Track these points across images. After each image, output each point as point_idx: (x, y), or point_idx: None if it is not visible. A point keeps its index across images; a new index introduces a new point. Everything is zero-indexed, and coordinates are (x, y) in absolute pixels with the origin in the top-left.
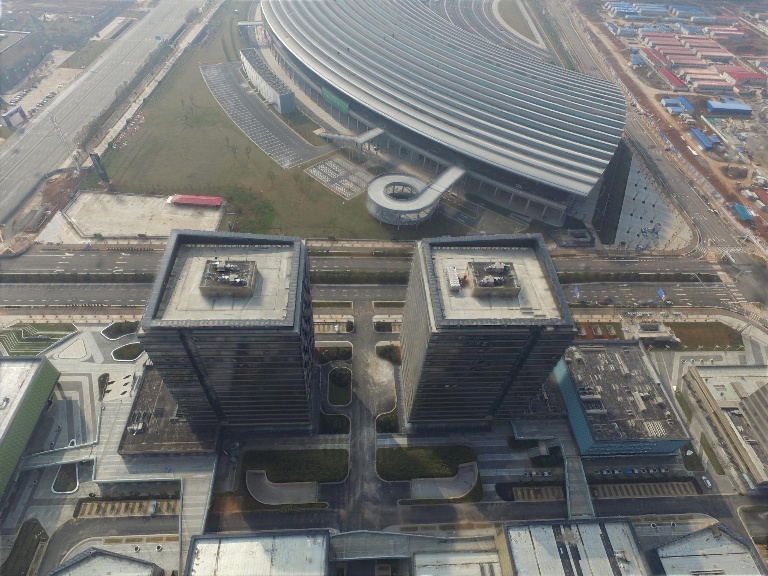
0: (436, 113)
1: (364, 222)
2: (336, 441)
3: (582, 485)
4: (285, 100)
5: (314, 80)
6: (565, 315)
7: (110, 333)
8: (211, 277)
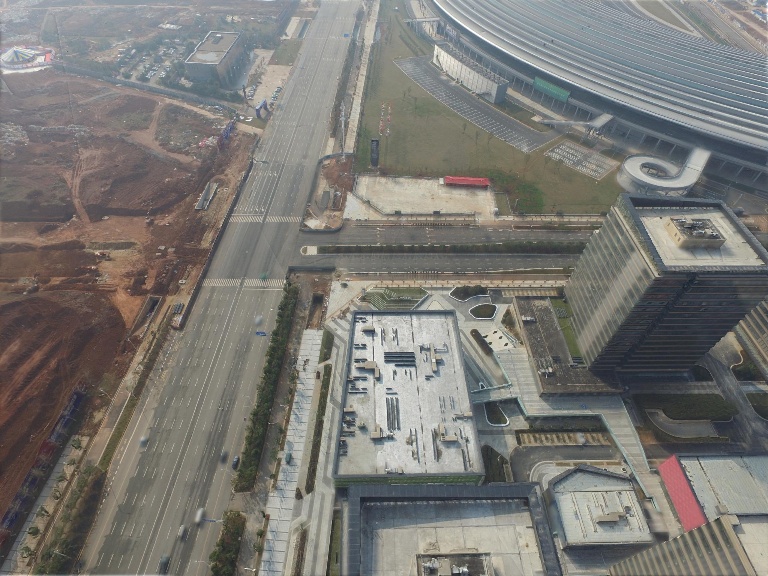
0: (672, 98)
1: None
2: (706, 387)
3: None
4: (501, 90)
5: (520, 71)
6: None
7: (459, 295)
8: (685, 232)
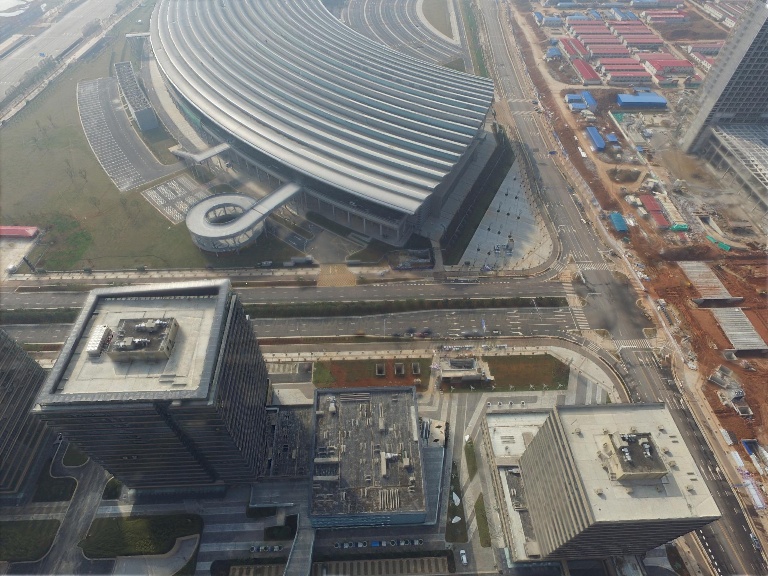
0: (277, 126)
1: (183, 249)
2: (52, 510)
3: (305, 564)
4: (142, 116)
5: (179, 93)
6: (200, 385)
7: None
8: None
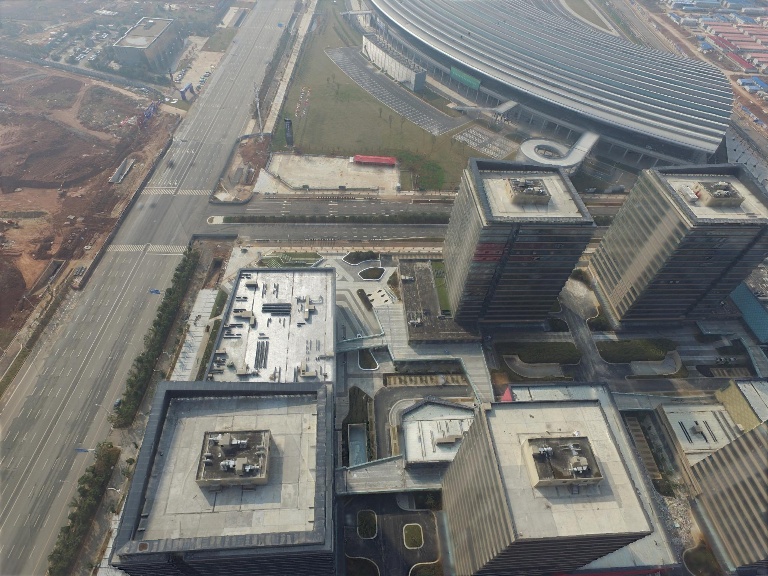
0: (568, 86)
1: None
2: (562, 337)
3: (766, 364)
4: (419, 78)
5: (439, 61)
6: None
7: (351, 260)
8: (518, 189)
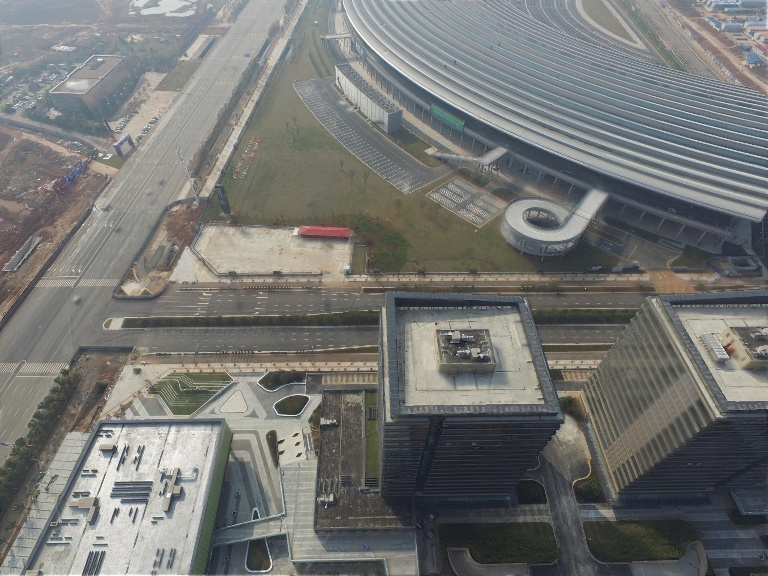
0: (569, 130)
1: (503, 252)
2: (535, 513)
3: None
4: (393, 118)
5: (419, 96)
6: None
7: (267, 384)
8: (448, 351)
